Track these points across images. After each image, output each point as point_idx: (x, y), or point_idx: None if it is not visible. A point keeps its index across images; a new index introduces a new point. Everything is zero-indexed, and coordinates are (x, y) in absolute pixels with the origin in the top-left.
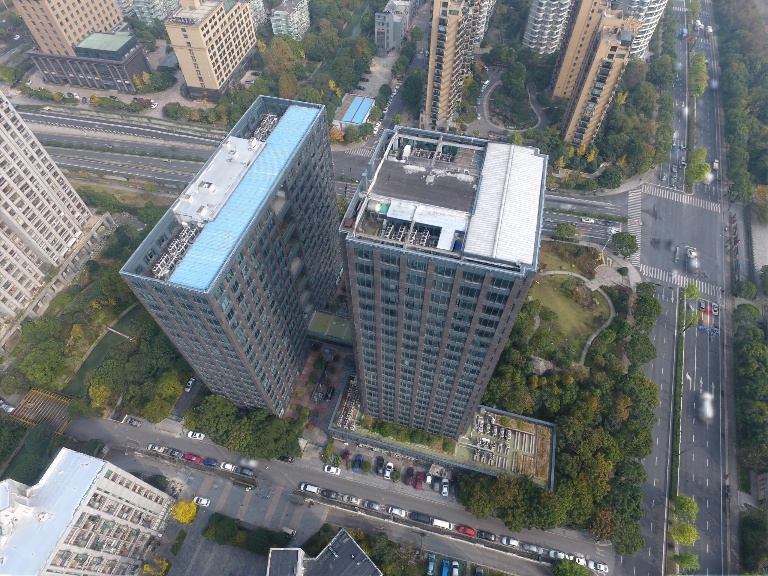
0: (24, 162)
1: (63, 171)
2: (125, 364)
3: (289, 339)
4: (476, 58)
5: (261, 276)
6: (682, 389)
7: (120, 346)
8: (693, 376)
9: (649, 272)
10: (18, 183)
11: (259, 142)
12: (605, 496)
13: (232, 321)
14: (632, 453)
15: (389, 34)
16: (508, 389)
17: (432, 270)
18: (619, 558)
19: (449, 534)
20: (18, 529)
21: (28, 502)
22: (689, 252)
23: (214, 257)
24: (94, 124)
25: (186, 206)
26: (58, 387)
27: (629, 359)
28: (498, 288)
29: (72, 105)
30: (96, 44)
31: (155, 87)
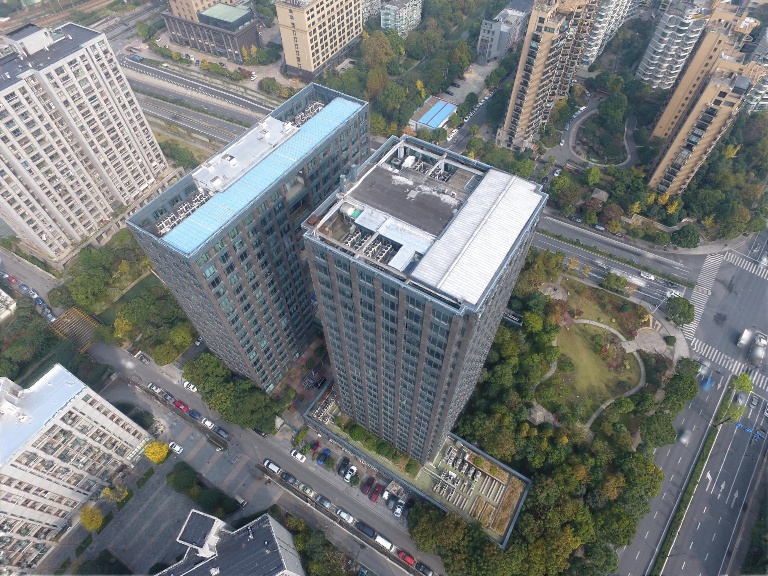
0: (115, 108)
1: (160, 123)
2: (150, 305)
3: (289, 320)
4: (580, 81)
5: (260, 254)
6: (696, 487)
7: (153, 288)
8: (715, 477)
9: (701, 349)
10: (106, 126)
11: (293, 127)
12: (561, 573)
13: (216, 289)
14: (608, 538)
15: (493, 43)
16: (491, 429)
17: (378, 286)
18: None
19: (388, 555)
20: (2, 422)
21: (17, 402)
22: (758, 338)
23: (209, 226)
24: (199, 86)
25: (205, 174)
26: (96, 311)
27: (641, 436)
28: (439, 320)
29: (186, 65)
30: (217, 13)
31: (259, 61)
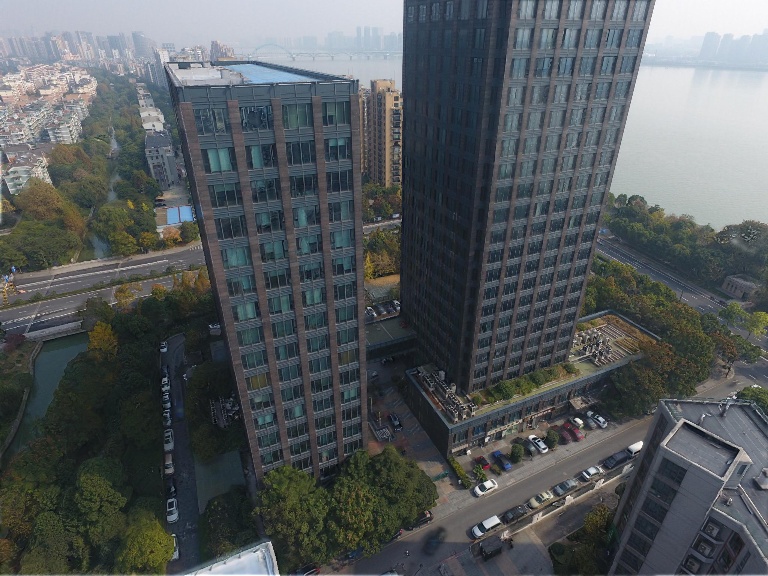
0: None
1: None
2: (18, 572)
3: None
4: None
5: None
6: None
7: None
8: None
9: None
10: None
11: None
12: None
13: None
14: None
15: (166, 167)
16: None
17: None
18: (750, 377)
19: None
20: None
21: None
22: None
23: None
24: None
25: None
26: None
27: None
28: None
29: None
30: None
31: None
